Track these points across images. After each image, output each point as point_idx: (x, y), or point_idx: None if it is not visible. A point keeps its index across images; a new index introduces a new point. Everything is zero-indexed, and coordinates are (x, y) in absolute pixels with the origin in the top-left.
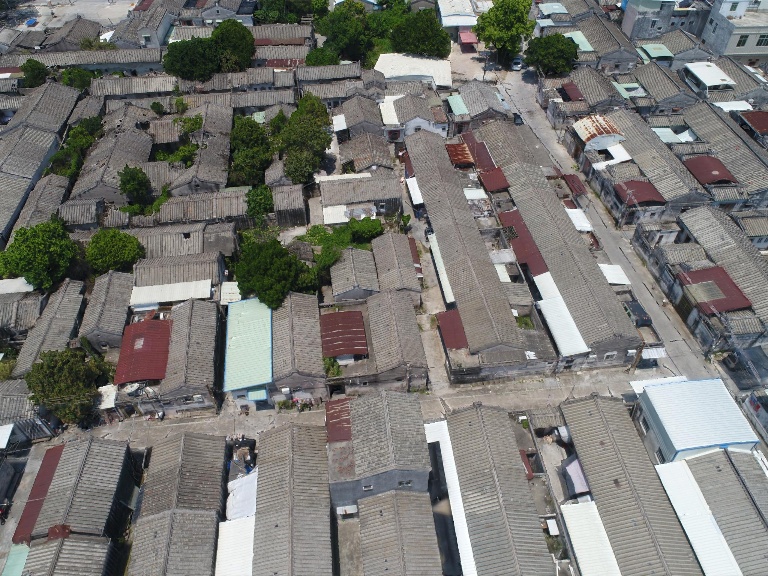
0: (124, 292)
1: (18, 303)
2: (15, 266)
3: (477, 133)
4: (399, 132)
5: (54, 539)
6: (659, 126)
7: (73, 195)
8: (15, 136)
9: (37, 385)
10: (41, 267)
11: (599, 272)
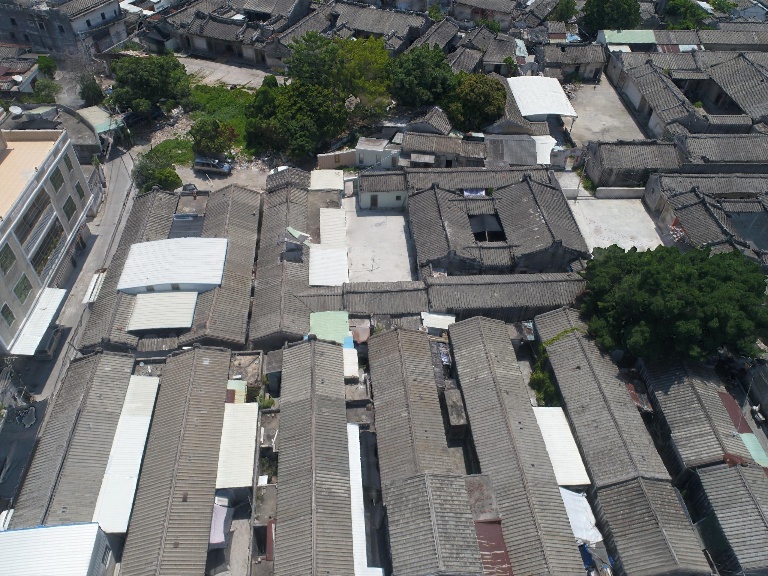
0: None
1: None
2: None
3: None
4: None
5: None
6: None
7: None
8: None
9: None
10: None
11: None
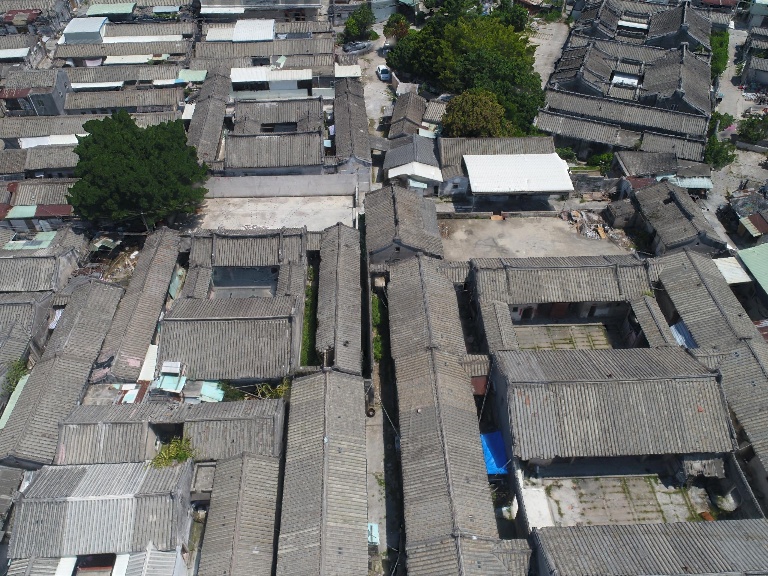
0: None
1: None
2: None
3: None
4: None
5: (16, 188)
6: None
7: None
8: None
9: None
10: None
11: None
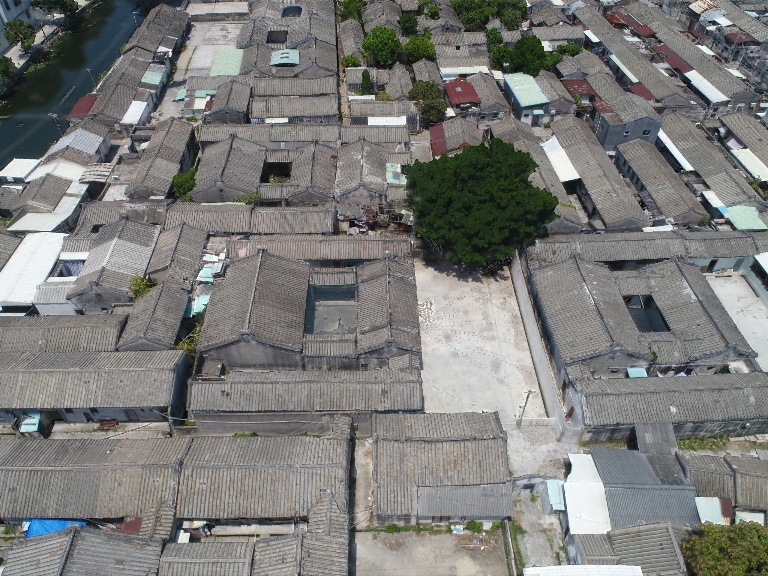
0: (435, 70)
1: (376, 70)
2: (376, 47)
3: (623, 10)
4: (565, 11)
5: None
6: (747, 10)
7: (369, 30)
8: (311, 0)
9: (420, 94)
10: (389, 49)
11: (727, 70)
